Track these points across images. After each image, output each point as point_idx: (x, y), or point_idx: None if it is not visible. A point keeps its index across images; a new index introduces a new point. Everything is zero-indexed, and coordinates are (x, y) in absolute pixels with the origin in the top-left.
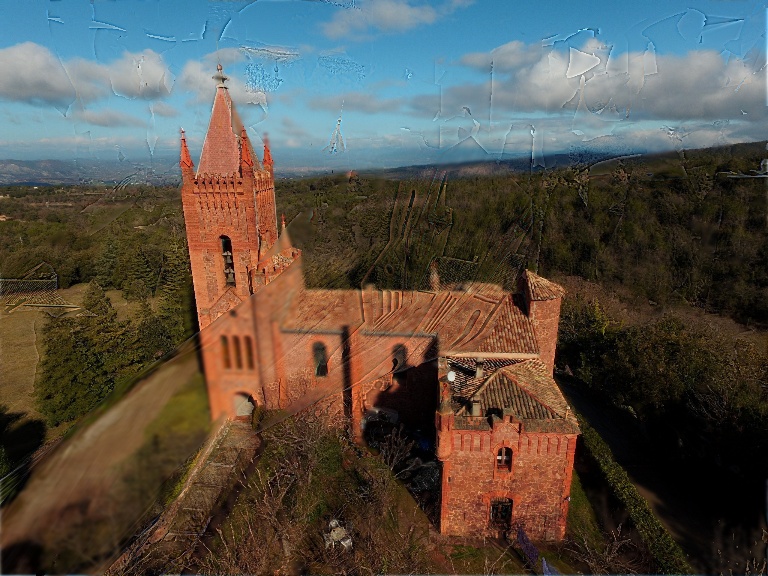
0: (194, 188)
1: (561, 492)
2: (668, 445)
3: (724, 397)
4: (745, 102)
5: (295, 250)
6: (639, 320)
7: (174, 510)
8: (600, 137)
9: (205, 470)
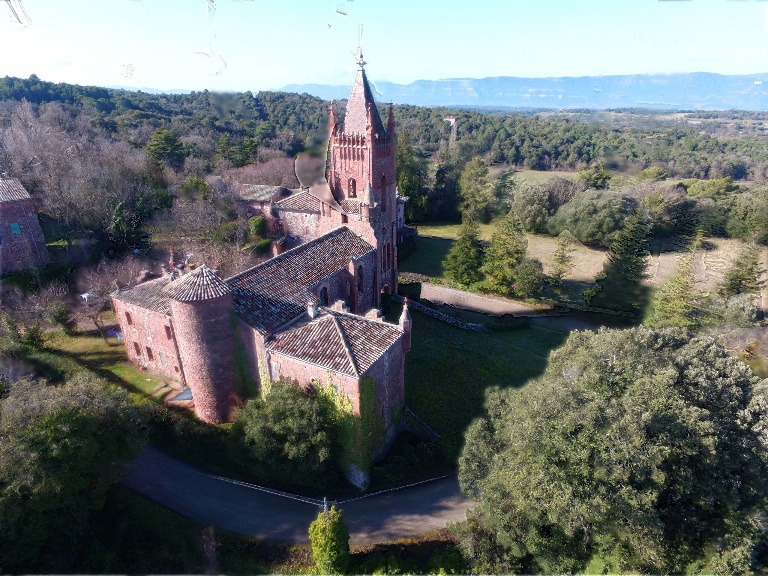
0: None
1: None
2: None
3: None
4: None
5: (375, 205)
6: None
7: None
8: None
9: None
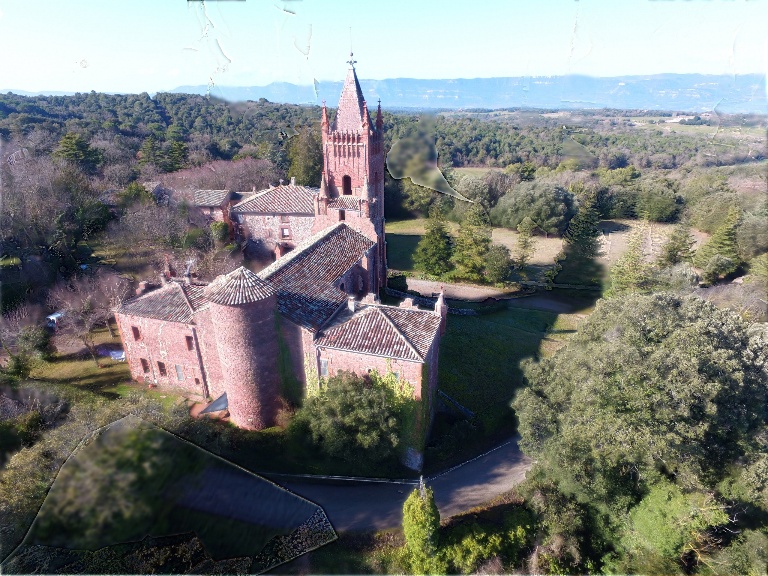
0: None
1: None
2: None
3: None
4: None
5: (375, 200)
6: None
7: None
8: None
9: None
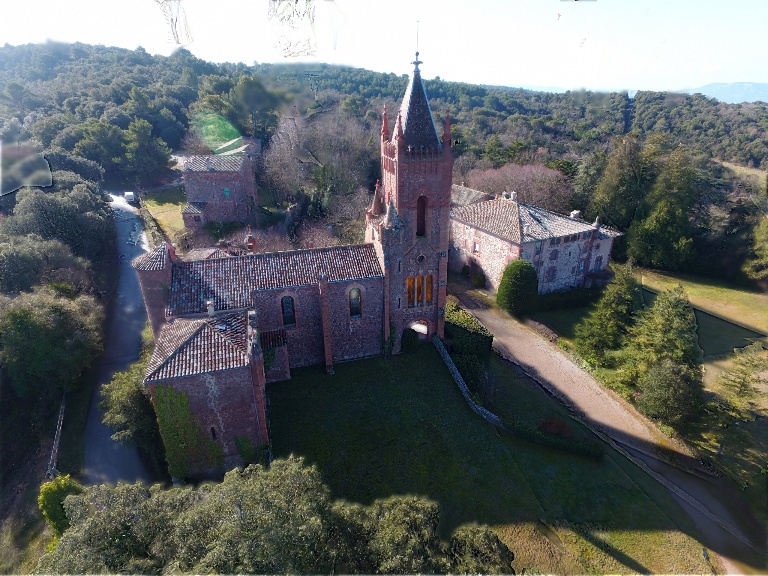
0: None
1: None
2: None
3: None
4: None
5: (389, 227)
6: None
7: None
8: None
9: None
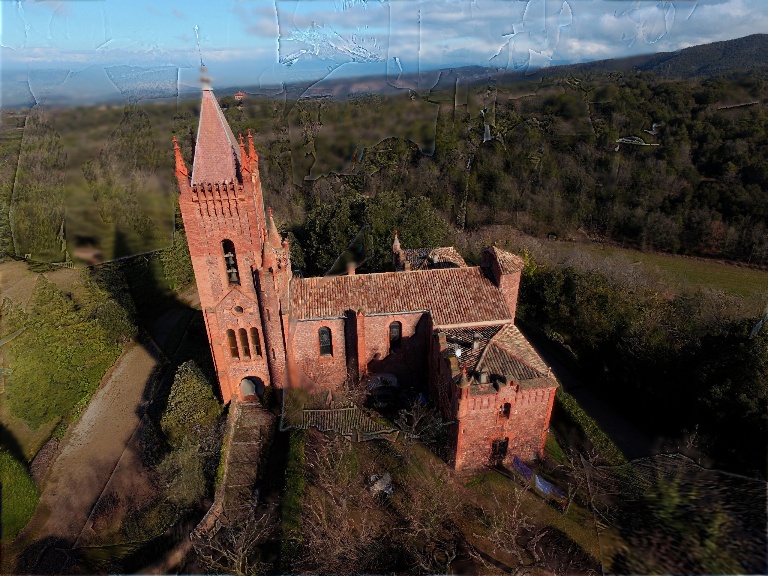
0: (192, 196)
1: (543, 427)
2: (596, 371)
3: (642, 339)
4: (635, 56)
5: None
6: (556, 259)
7: (223, 490)
8: (525, 97)
9: (235, 450)
